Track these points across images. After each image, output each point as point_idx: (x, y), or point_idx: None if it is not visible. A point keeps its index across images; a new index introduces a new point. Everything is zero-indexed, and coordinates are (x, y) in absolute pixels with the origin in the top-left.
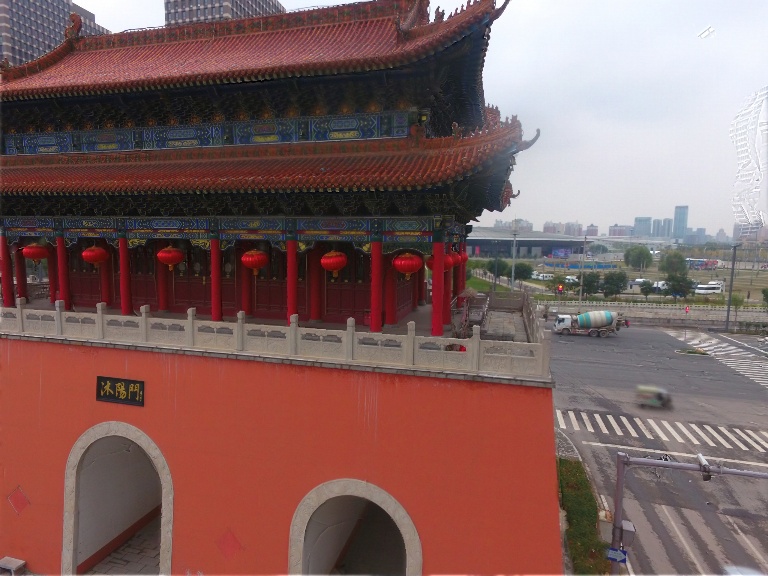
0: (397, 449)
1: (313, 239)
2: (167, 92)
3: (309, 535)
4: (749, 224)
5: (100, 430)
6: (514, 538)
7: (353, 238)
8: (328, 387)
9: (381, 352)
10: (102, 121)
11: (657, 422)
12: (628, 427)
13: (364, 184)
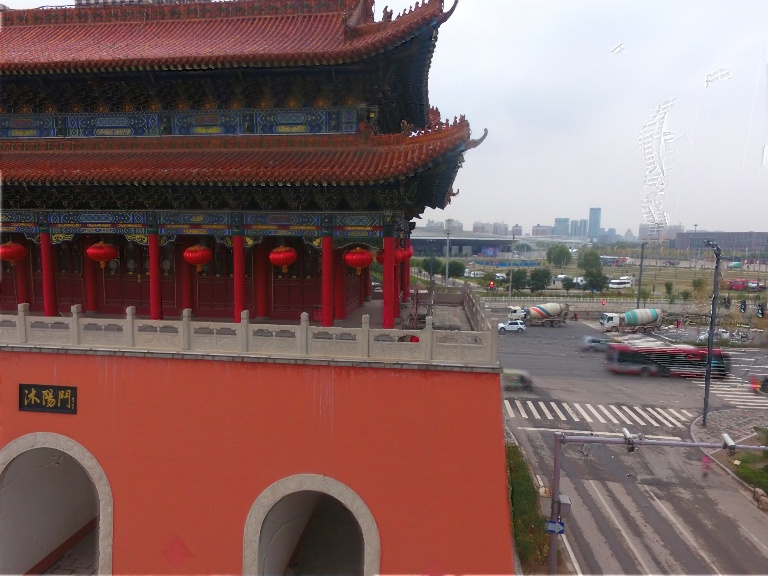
0: (353, 441)
1: (261, 234)
2: (96, 76)
3: (264, 534)
4: (656, 224)
5: (24, 443)
6: (467, 518)
7: (303, 233)
8: (282, 383)
9: (336, 346)
10: (17, 104)
11: (582, 406)
12: (557, 412)
13: (316, 178)
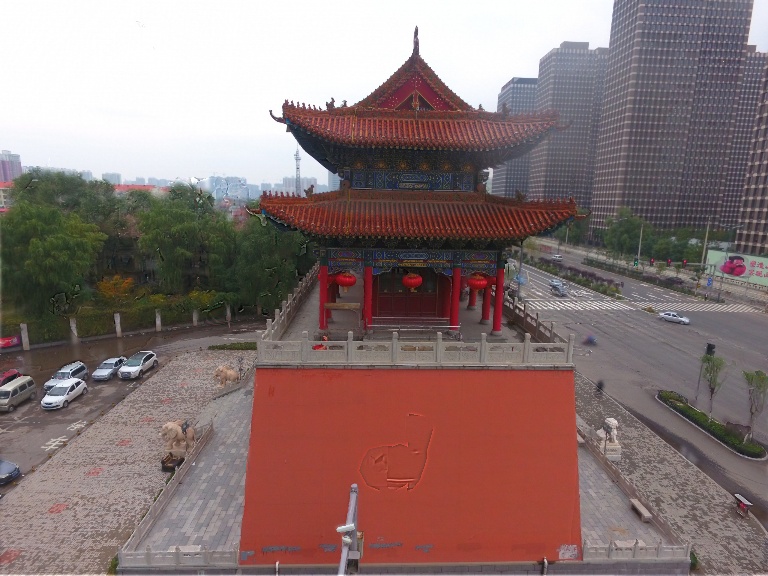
0: None
1: None
2: None
3: None
4: None
5: None
6: None
7: None
8: None
9: None
10: None
11: None
12: None
13: None
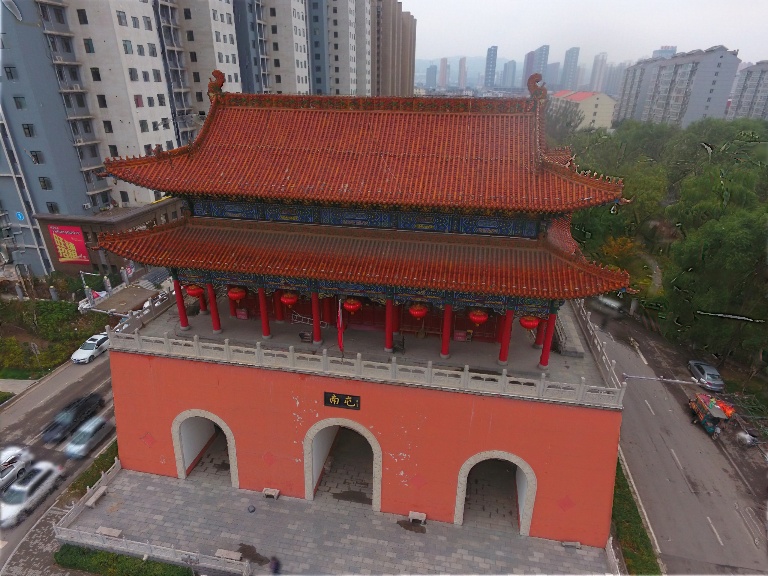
0: None
1: None
2: None
3: None
4: None
5: None
6: None
7: None
8: None
9: None
10: None
11: None
12: None
13: None
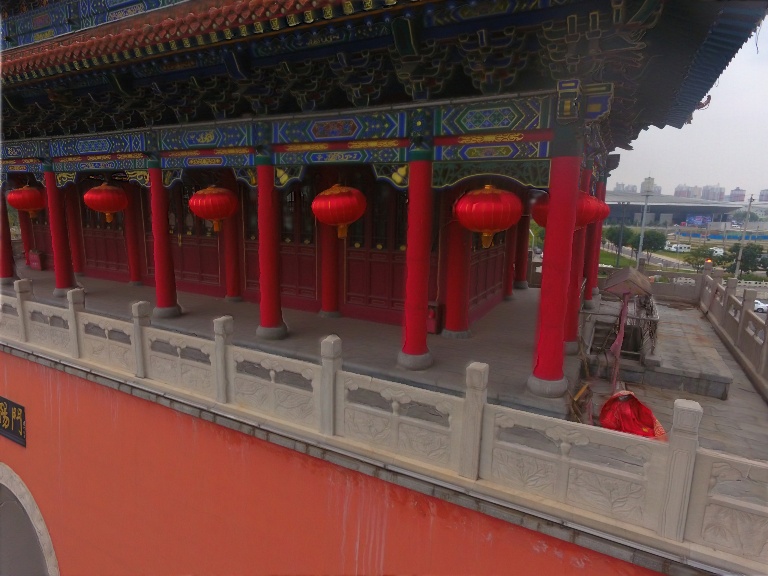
0: None
1: (299, 161)
2: None
3: None
4: None
5: None
6: None
7: (372, 155)
8: (282, 487)
9: (398, 429)
10: None
11: None
12: None
13: None
